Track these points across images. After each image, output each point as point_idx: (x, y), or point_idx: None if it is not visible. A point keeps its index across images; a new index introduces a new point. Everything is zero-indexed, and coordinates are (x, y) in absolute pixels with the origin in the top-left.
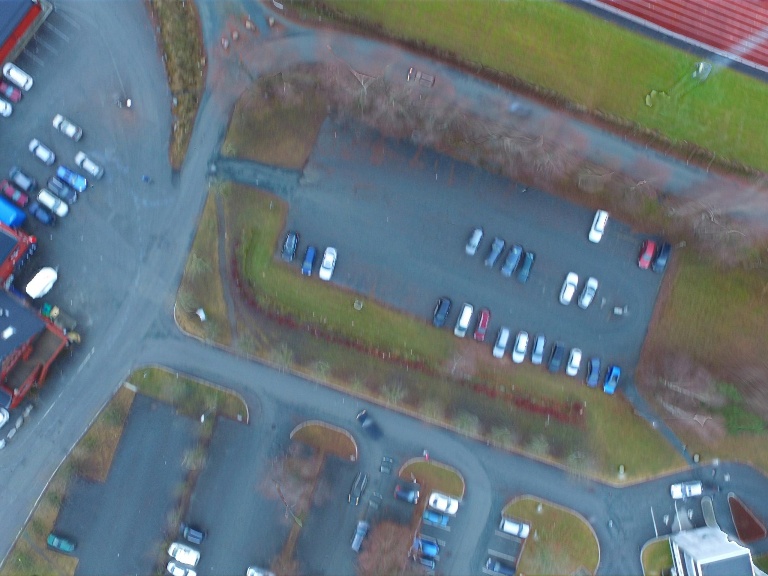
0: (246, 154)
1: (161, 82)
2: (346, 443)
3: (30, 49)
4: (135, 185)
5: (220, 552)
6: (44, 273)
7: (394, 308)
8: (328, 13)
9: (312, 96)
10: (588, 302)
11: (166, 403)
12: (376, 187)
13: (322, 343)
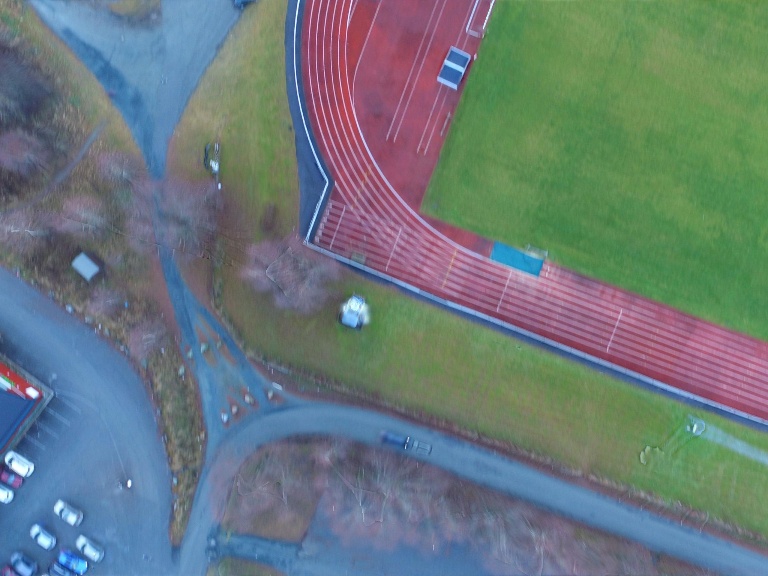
0: (245, 530)
1: (161, 462)
2: None
3: (31, 434)
4: (135, 564)
5: None
6: None
7: None
8: (326, 385)
9: (310, 473)
10: None
11: None
12: (374, 559)
13: None
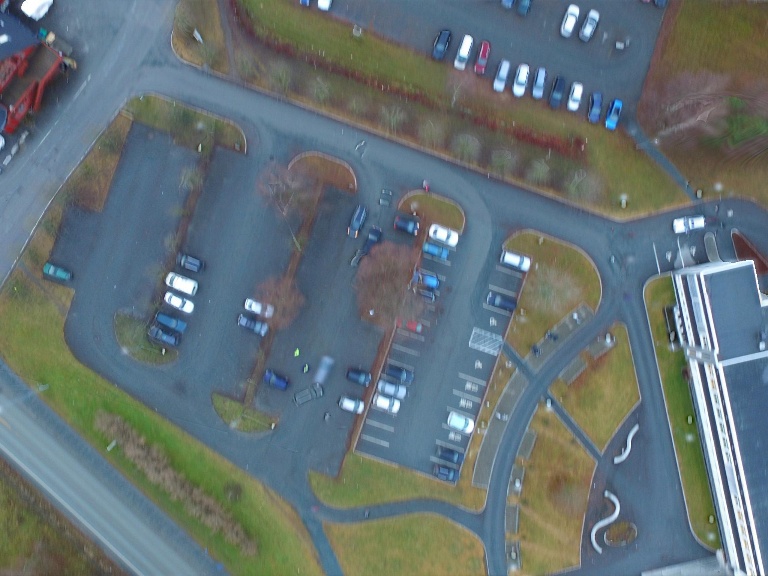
0: None
1: None
2: (345, 174)
3: None
4: None
5: (218, 284)
6: None
7: (393, 41)
8: None
9: None
10: (589, 32)
11: (163, 132)
12: None
13: (321, 73)
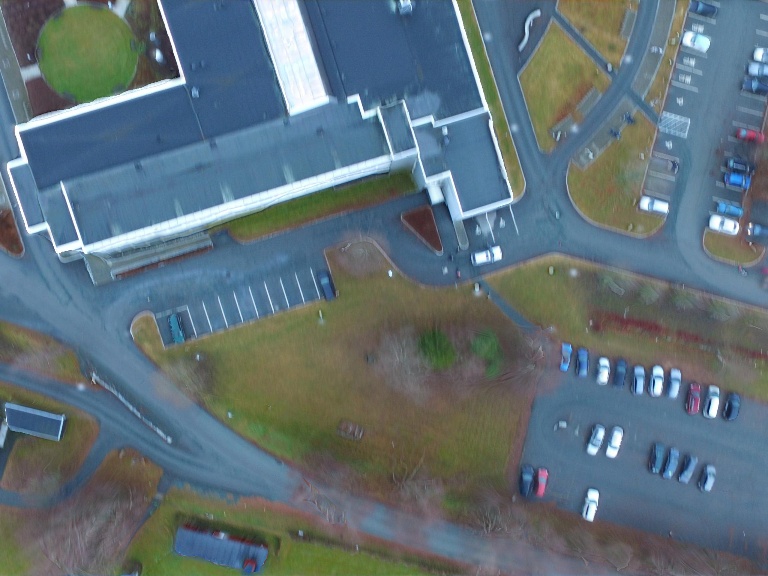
0: None
1: None
2: None
3: None
4: None
5: None
6: None
7: None
8: None
9: None
10: (600, 433)
11: None
12: None
13: None
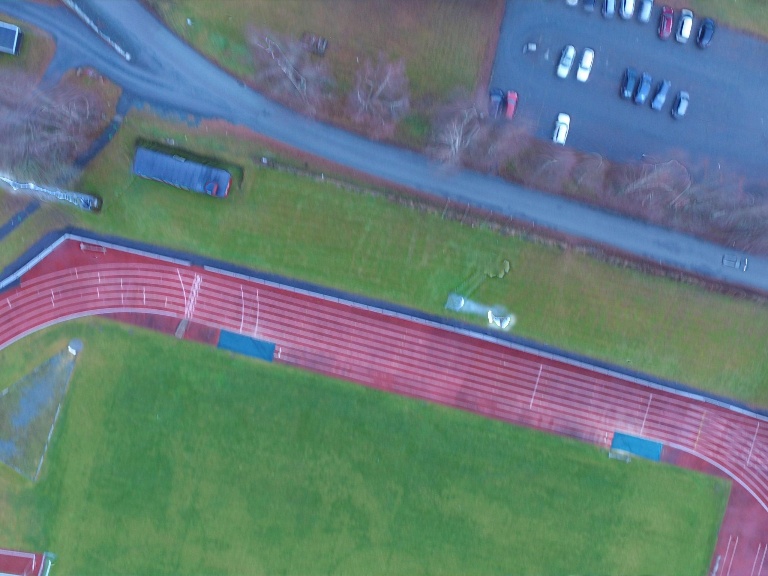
0: None
1: None
2: None
3: None
4: None
5: None
6: None
7: (749, 35)
8: None
9: None
10: (570, 51)
11: None
12: None
13: None
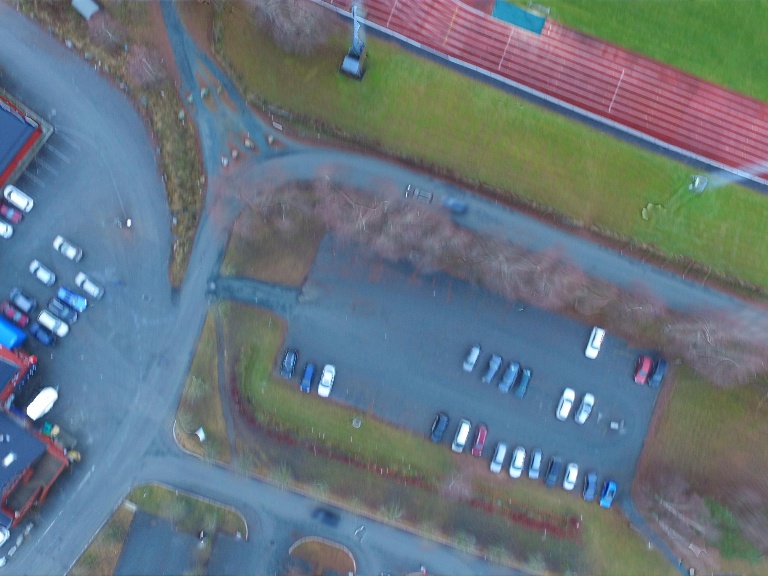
0: (245, 272)
1: (161, 202)
2: (344, 559)
3: (31, 170)
4: (135, 304)
5: None
6: (45, 394)
7: (392, 423)
8: (327, 131)
9: (311, 215)
10: (585, 419)
11: (166, 520)
12: (374, 304)
13: (321, 460)
